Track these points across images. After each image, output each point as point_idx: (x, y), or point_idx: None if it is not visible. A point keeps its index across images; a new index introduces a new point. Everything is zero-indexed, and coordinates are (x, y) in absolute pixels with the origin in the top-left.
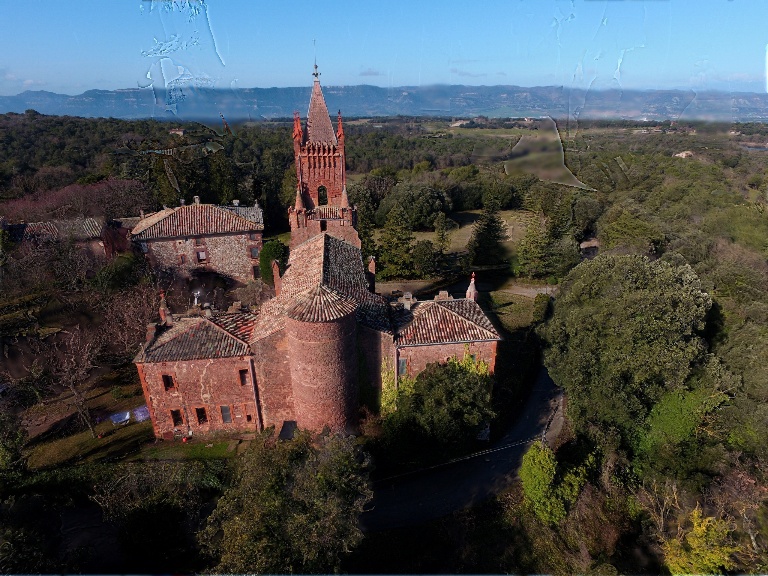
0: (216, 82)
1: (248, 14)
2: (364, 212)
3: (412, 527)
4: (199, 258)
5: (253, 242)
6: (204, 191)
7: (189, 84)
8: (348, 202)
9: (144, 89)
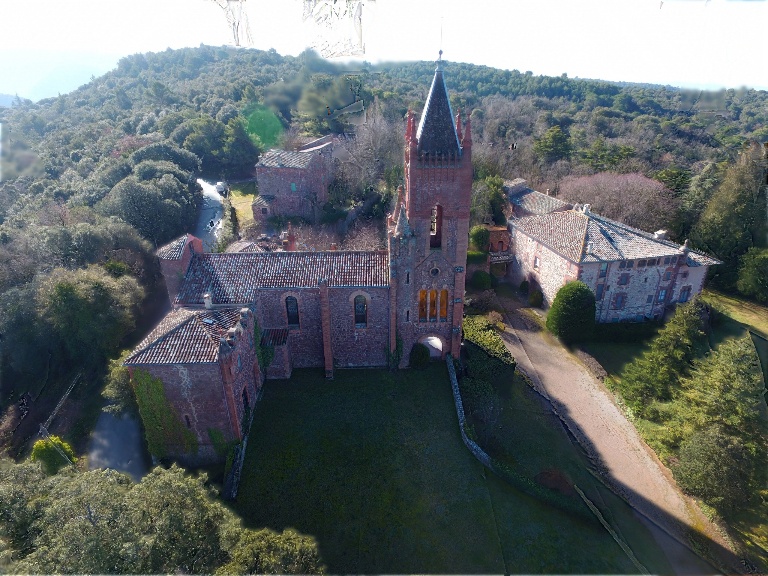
0: (307, 79)
1: (363, 8)
2: (692, 314)
3: (104, 400)
4: (536, 263)
5: (571, 273)
6: (762, 222)
7: (340, 80)
8: (398, 225)
9: (695, 77)
